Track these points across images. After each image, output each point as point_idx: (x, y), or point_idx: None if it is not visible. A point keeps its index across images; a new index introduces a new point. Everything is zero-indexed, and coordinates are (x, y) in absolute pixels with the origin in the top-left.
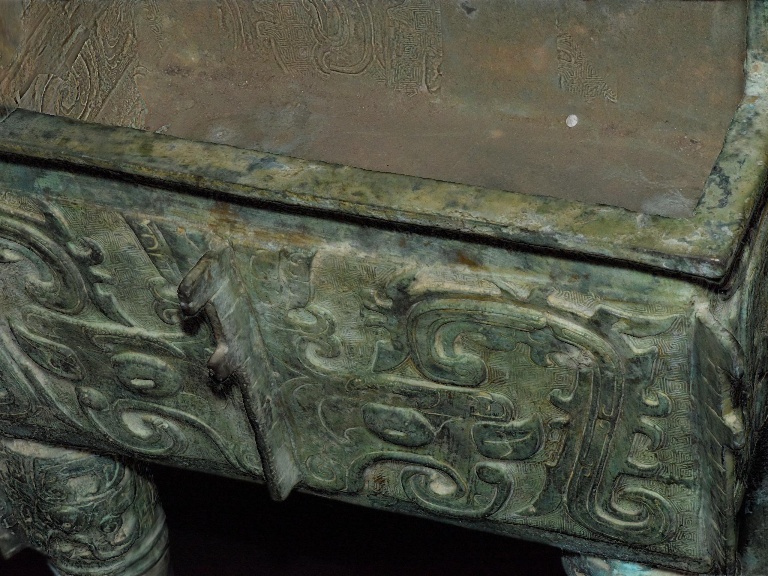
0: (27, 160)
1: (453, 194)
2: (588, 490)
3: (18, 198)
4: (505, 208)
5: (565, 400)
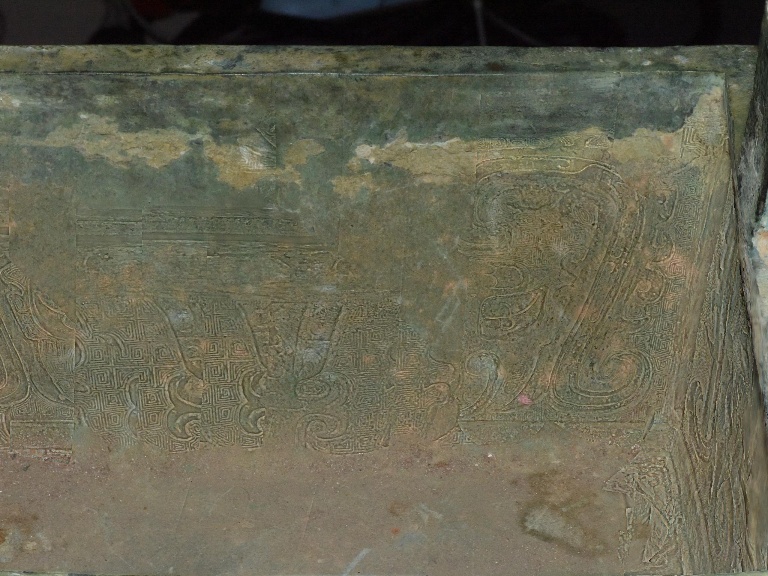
0: (482, 116)
1: (57, 63)
2: (2, 353)
3: (494, 141)
4: (8, 57)
5: (1, 256)
